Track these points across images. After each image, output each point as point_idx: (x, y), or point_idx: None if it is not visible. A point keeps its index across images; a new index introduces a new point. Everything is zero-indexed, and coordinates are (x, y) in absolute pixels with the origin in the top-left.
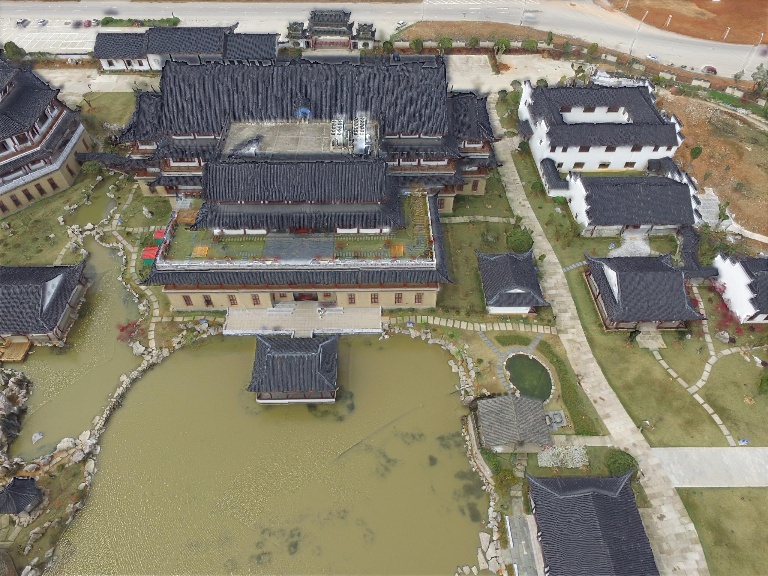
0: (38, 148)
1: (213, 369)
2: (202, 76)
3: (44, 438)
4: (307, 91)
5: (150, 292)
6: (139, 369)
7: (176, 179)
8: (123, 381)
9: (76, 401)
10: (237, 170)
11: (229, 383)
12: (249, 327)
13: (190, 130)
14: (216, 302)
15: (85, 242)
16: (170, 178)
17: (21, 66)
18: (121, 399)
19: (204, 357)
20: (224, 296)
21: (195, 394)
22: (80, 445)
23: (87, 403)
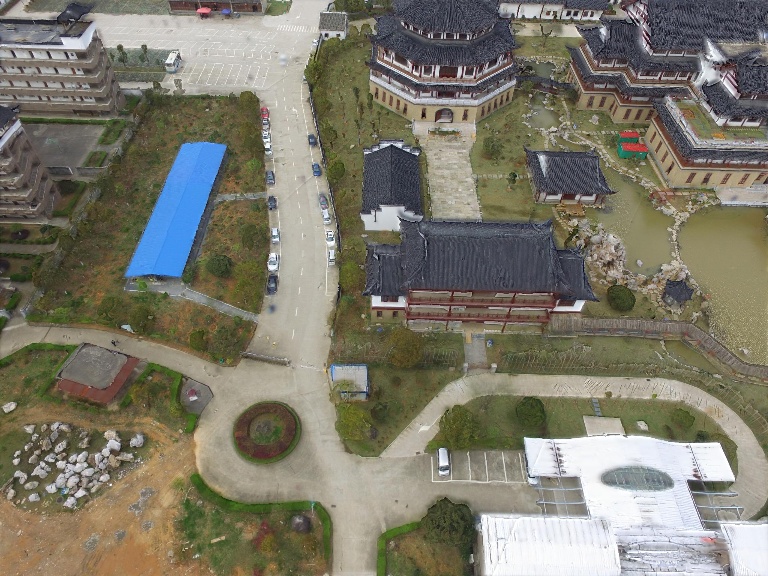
0: (511, 65)
1: (729, 227)
2: (680, 5)
3: (645, 264)
4: (764, 19)
5: (641, 175)
6: (677, 224)
7: (641, 90)
8: (672, 231)
9: (645, 243)
10: (762, 71)
11: (745, 237)
12: (739, 200)
13: (675, 47)
14: (711, 180)
15: (557, 140)
16: (636, 89)
17: (384, 12)
18: (678, 243)
19: (716, 219)
20: (723, 175)
21: (713, 247)
22: (678, 268)
23: (653, 245)
